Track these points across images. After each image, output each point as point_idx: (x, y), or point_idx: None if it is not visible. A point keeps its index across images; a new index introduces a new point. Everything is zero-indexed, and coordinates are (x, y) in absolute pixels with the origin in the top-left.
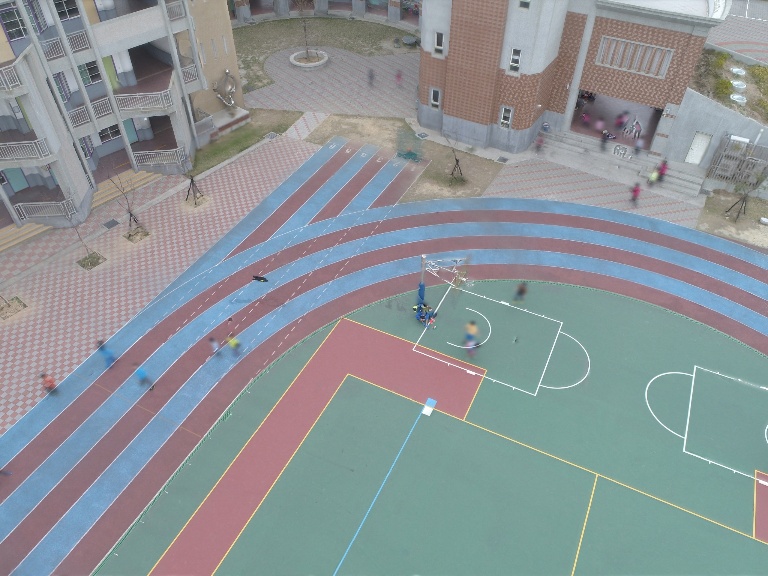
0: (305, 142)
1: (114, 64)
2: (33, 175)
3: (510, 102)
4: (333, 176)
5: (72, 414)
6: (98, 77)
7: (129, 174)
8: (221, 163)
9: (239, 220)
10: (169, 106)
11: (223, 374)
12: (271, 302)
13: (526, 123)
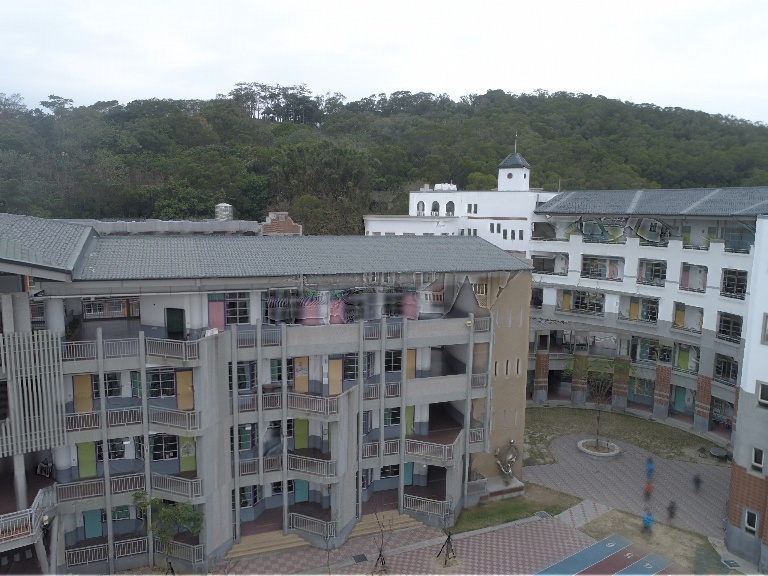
0: (579, 531)
1: (414, 413)
2: (315, 491)
3: None
4: None
5: None
6: (398, 421)
7: (393, 514)
8: (483, 528)
9: None
10: (449, 459)
11: None
12: None
13: None
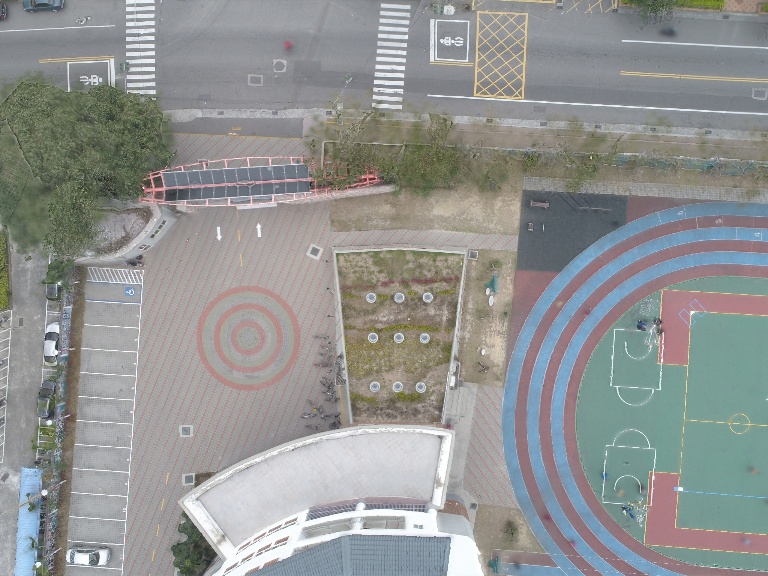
0: None
1: None
2: None
3: None
4: None
5: None
6: None
7: None
8: None
9: None
10: None
11: None
12: None
13: None
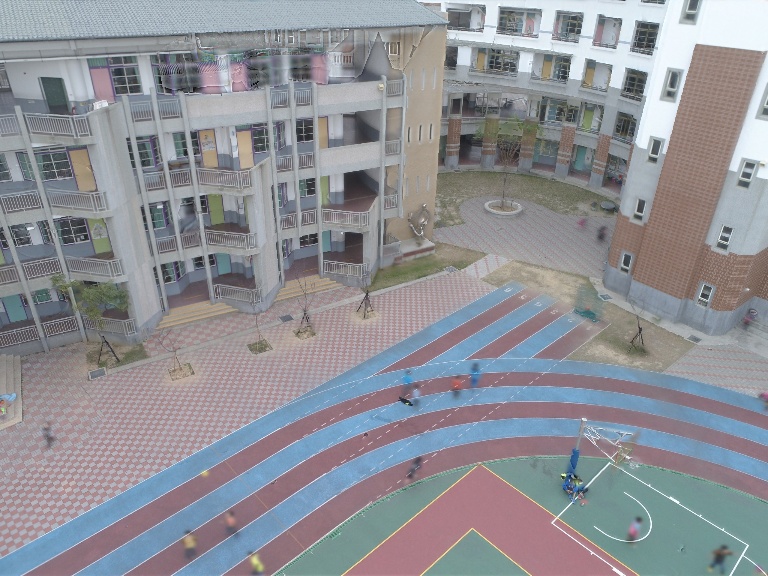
0: (482, 281)
1: (329, 183)
2: (237, 263)
3: (712, 280)
4: (502, 318)
5: (197, 485)
6: (313, 192)
7: (315, 278)
8: (398, 285)
9: (400, 340)
10: (365, 226)
11: (344, 488)
12: (410, 428)
13: (729, 305)
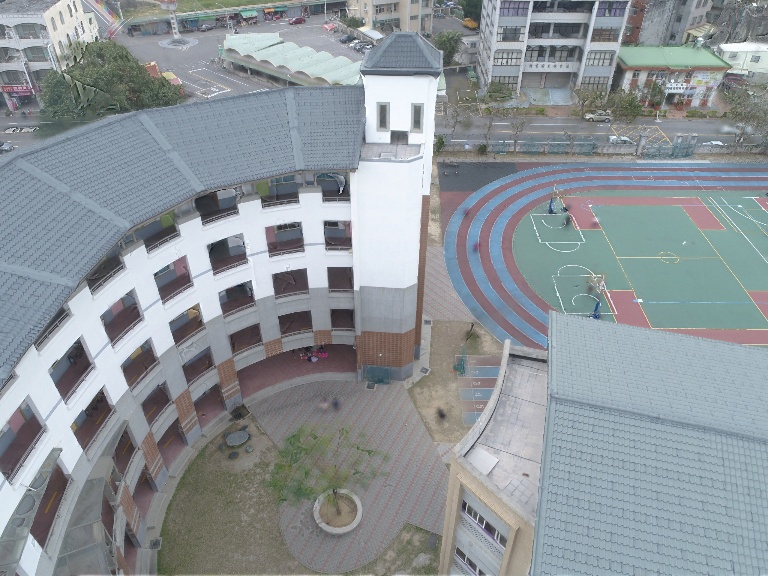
0: None
1: None
2: None
3: None
4: None
5: None
6: None
7: None
8: None
9: None
10: None
11: None
12: None
13: None
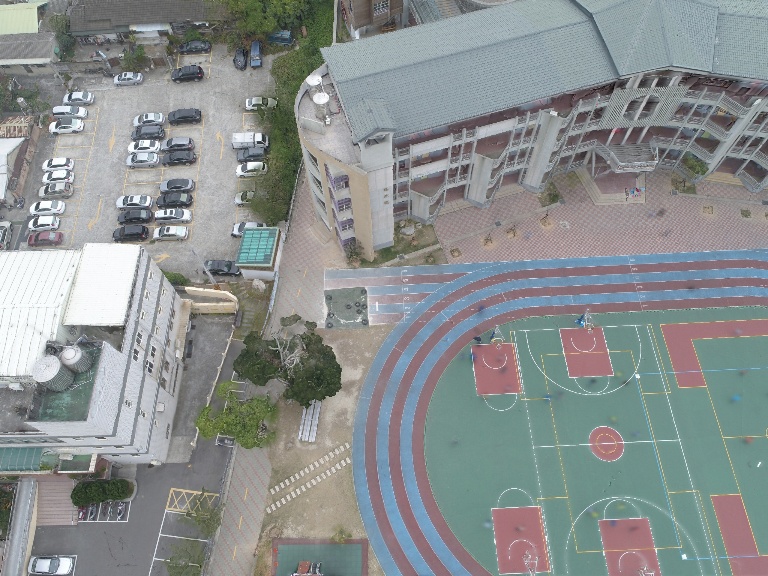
0: None
1: None
2: None
3: None
4: None
5: (701, 264)
6: None
7: None
8: None
9: None
10: None
11: (752, 295)
12: None
13: None
